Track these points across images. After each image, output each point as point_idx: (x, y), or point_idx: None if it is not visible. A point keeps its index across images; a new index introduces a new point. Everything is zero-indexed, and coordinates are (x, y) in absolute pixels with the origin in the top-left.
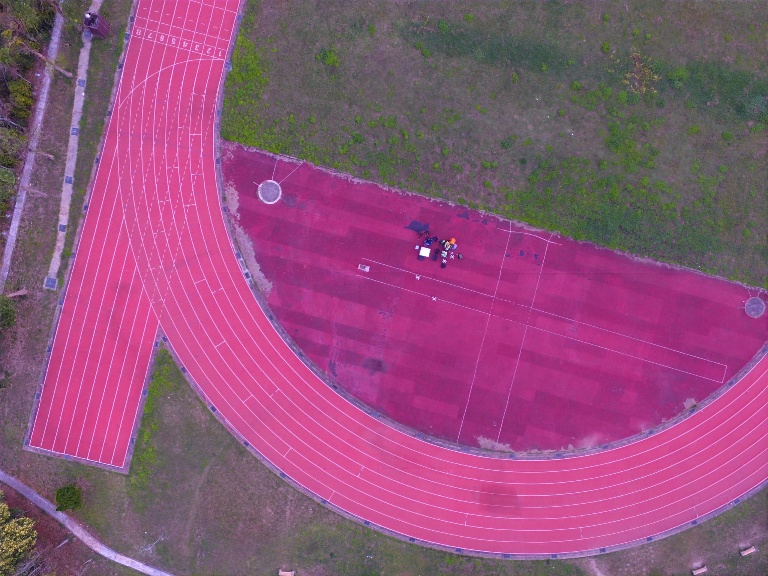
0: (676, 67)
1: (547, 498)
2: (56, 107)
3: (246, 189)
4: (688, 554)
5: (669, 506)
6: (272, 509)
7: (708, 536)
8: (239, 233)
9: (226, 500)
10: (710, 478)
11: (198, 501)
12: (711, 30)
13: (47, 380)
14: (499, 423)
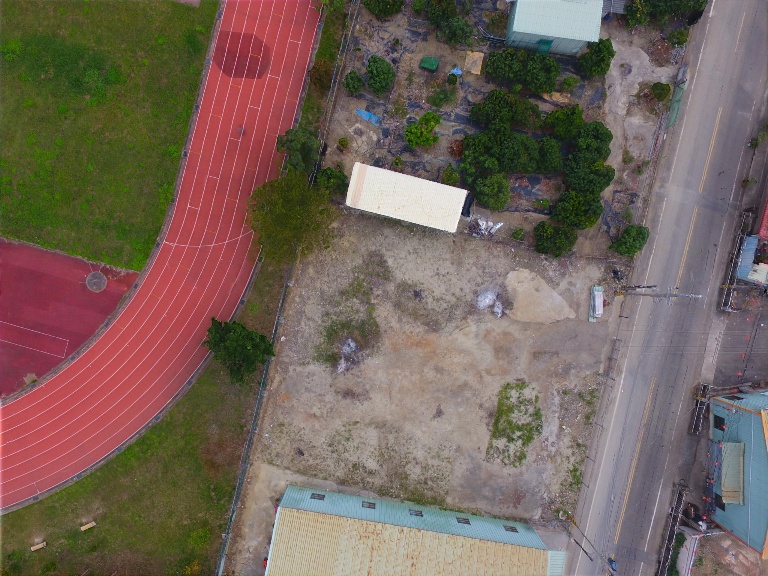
0: (10, 39)
1: None
2: None
3: None
4: (30, 530)
5: (8, 482)
6: None
7: (50, 512)
8: None
9: None
10: (51, 453)
11: None
12: (46, 2)
13: None
14: None
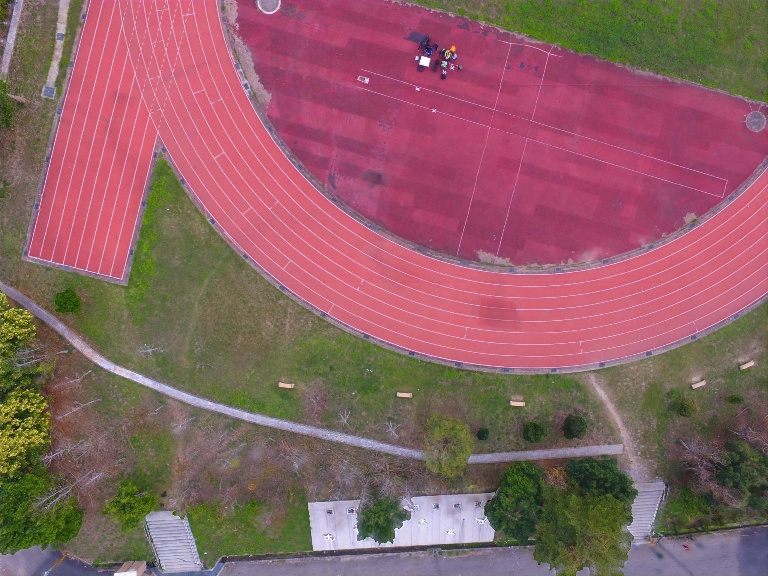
0: None
1: (547, 312)
2: None
3: None
4: (687, 369)
5: (669, 320)
6: (271, 322)
7: (707, 351)
8: (238, 43)
9: (225, 312)
10: (710, 293)
11: (197, 313)
12: None
13: (46, 190)
14: (499, 237)
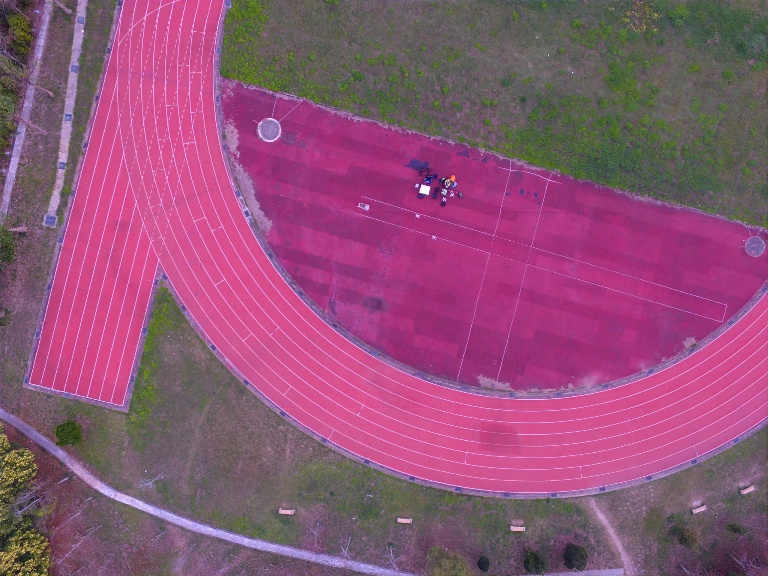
0: (676, 5)
1: (547, 437)
2: (55, 44)
3: (246, 127)
4: (688, 493)
5: (669, 445)
6: (272, 448)
7: (708, 475)
8: (239, 171)
9: (226, 438)
10: (710, 417)
11: (198, 439)
12: None
13: (47, 318)
14: (499, 362)
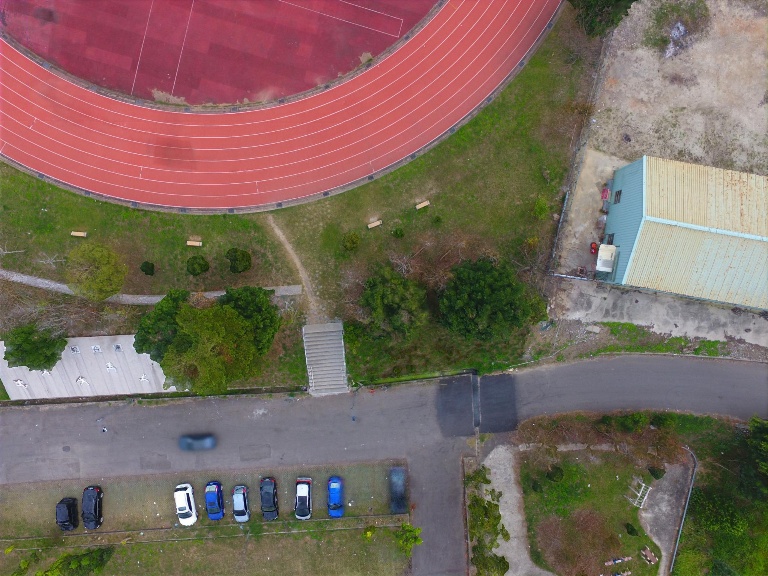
0: None
1: (223, 152)
2: None
3: None
4: (365, 209)
5: (345, 160)
6: None
7: (385, 191)
8: None
9: None
10: (386, 133)
11: None
12: None
13: None
14: (173, 75)
